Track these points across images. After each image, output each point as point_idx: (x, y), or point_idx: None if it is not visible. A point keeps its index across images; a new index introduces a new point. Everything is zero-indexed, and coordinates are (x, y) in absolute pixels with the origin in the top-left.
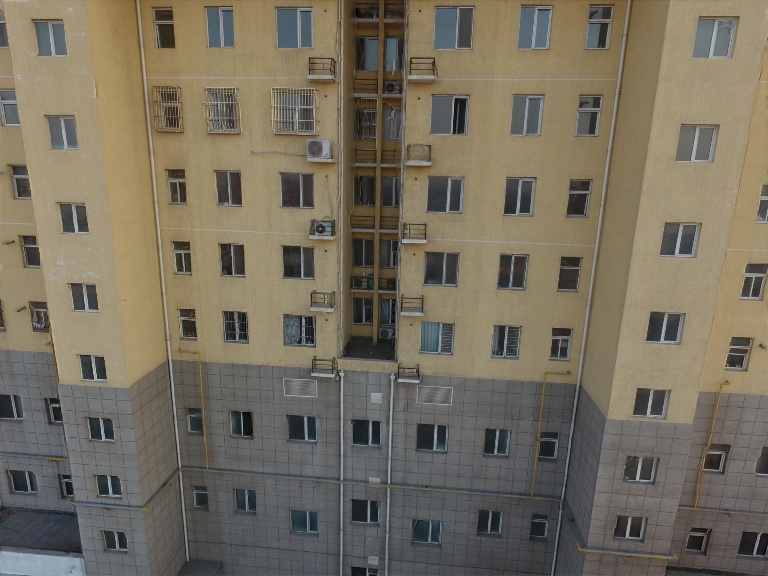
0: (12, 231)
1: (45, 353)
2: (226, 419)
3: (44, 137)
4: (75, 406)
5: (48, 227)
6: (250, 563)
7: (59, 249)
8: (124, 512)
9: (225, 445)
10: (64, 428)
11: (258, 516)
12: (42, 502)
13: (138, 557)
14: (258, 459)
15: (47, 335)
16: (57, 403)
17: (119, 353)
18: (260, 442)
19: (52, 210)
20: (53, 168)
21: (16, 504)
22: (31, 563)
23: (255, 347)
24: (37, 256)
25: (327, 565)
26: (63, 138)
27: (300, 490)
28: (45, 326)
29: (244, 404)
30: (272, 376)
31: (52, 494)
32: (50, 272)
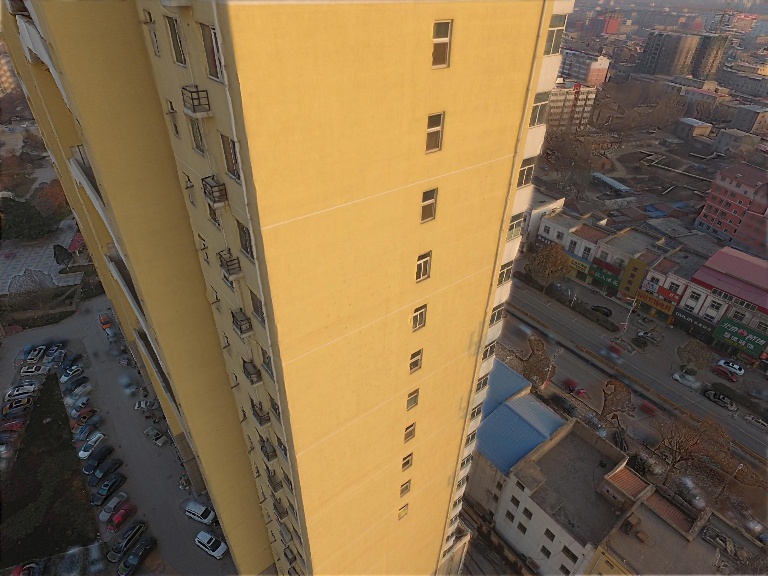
0: None
1: None
2: None
3: None
4: None
5: None
6: None
7: None
8: None
9: None
10: None
11: None
12: None
13: None
14: None
15: None
16: None
17: None
18: None
19: None
20: None
21: None
22: None
23: None
24: None
25: None
26: None
27: None
28: None
29: None
30: None
31: None
32: None
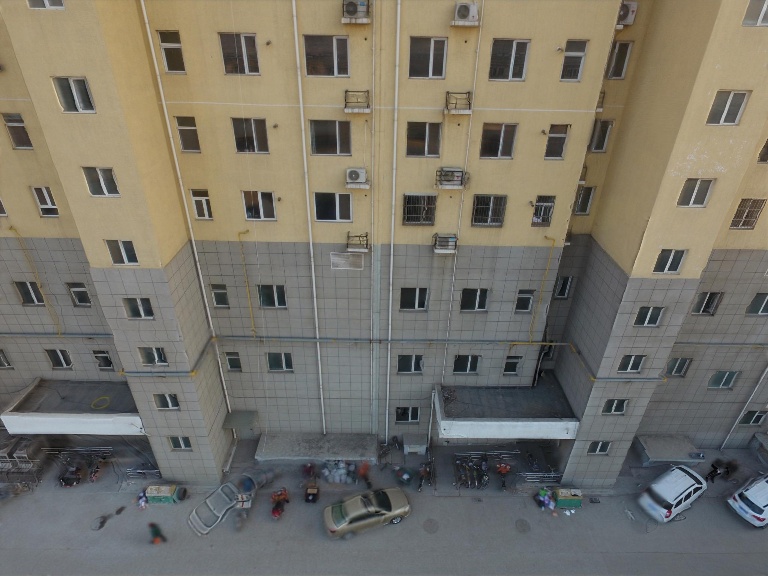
0: (546, 119)
1: (536, 247)
2: (696, 300)
3: (742, 10)
4: (638, 297)
5: (696, 118)
6: (659, 414)
7: (697, 142)
8: (640, 384)
9: (684, 322)
10: (616, 317)
11: (686, 378)
12: (483, 380)
13: (633, 417)
14: (709, 332)
15: (545, 229)
16: (525, 294)
17: (706, 246)
18: (719, 318)
19: (710, 99)
20: (737, 49)
21: (456, 383)
22: (526, 429)
23: (758, 233)
24: (558, 147)
25: (728, 411)
26: (761, 11)
27: (736, 355)
28: (546, 220)
29: (720, 286)
30: (761, 259)
31: (495, 373)
32: (674, 167)
